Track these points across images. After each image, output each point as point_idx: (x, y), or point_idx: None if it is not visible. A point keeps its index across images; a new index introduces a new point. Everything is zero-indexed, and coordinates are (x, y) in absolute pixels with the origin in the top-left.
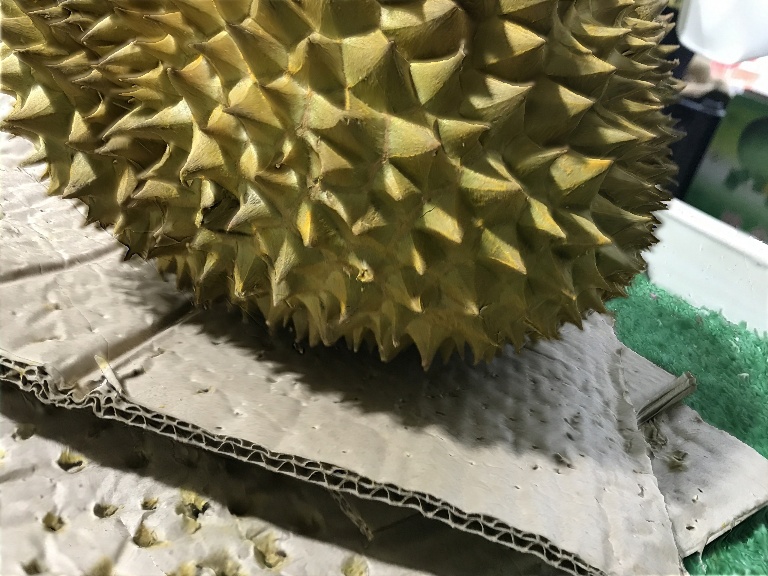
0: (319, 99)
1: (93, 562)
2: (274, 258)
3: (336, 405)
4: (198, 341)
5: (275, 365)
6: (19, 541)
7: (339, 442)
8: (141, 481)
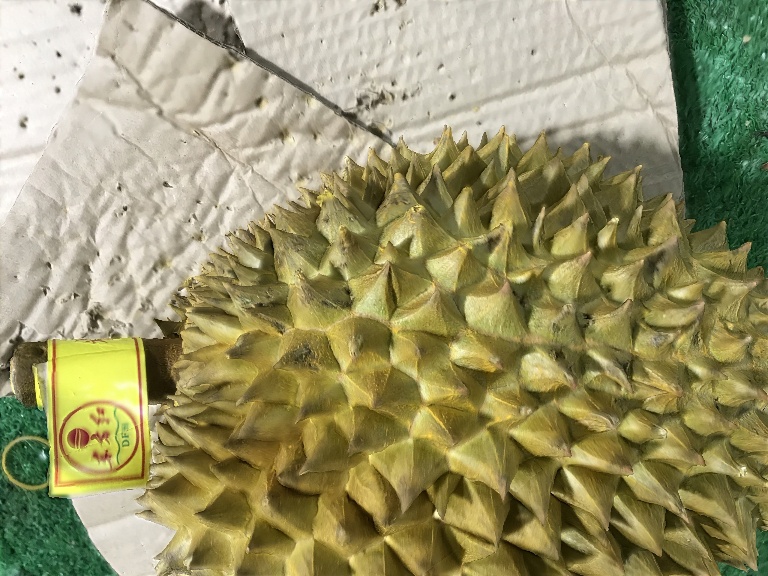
0: None
1: None
2: None
3: None
4: None
5: None
6: None
7: None
8: None
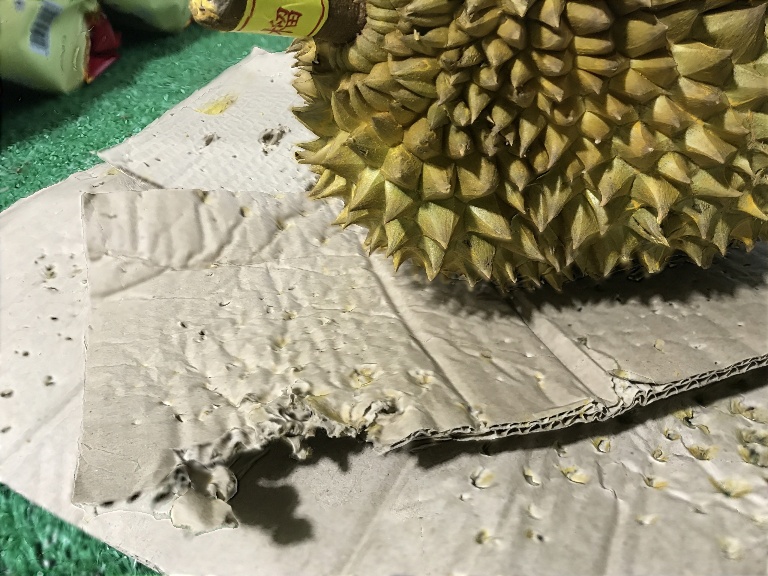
0: (761, 116)
1: (709, 485)
2: (710, 236)
3: (713, 302)
4: (574, 316)
5: (637, 300)
6: (669, 504)
7: (767, 325)
8: (648, 426)
